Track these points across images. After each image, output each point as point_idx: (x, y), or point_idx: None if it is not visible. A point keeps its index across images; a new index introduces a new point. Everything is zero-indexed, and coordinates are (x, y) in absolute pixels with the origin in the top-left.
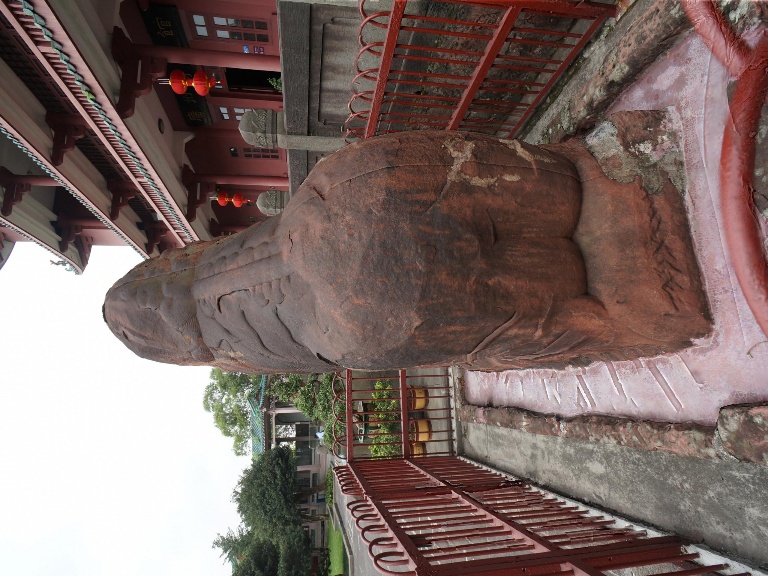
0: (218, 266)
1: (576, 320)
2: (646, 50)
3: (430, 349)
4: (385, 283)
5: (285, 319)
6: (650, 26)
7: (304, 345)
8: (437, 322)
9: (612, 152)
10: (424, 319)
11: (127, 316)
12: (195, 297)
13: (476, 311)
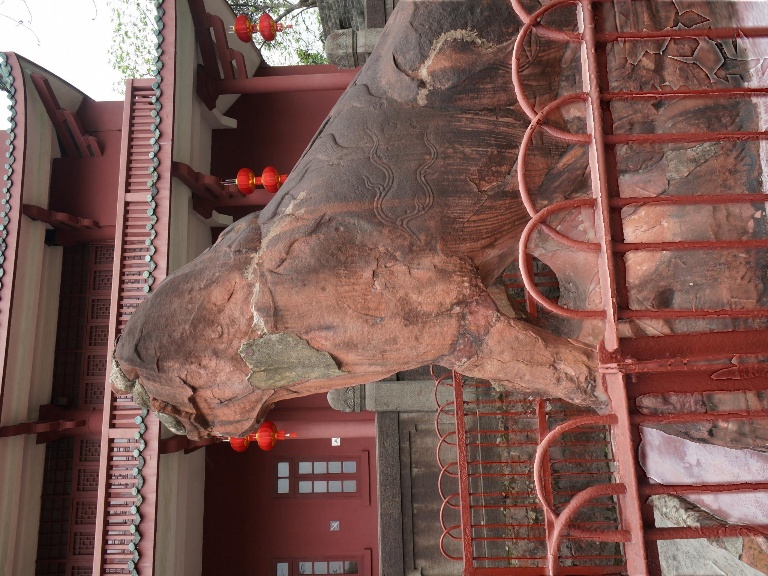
0: None
1: None
2: None
3: None
4: None
5: (363, 79)
6: None
7: (381, 94)
8: None
9: None
10: None
11: None
12: None
13: None
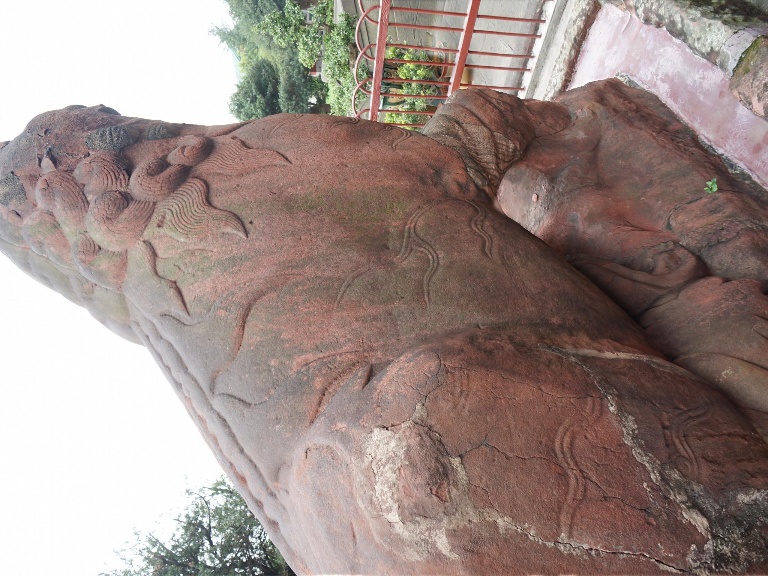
0: (172, 369)
1: None
2: None
3: None
4: None
5: None
6: None
7: None
8: None
9: None
10: None
11: None
12: None
13: None
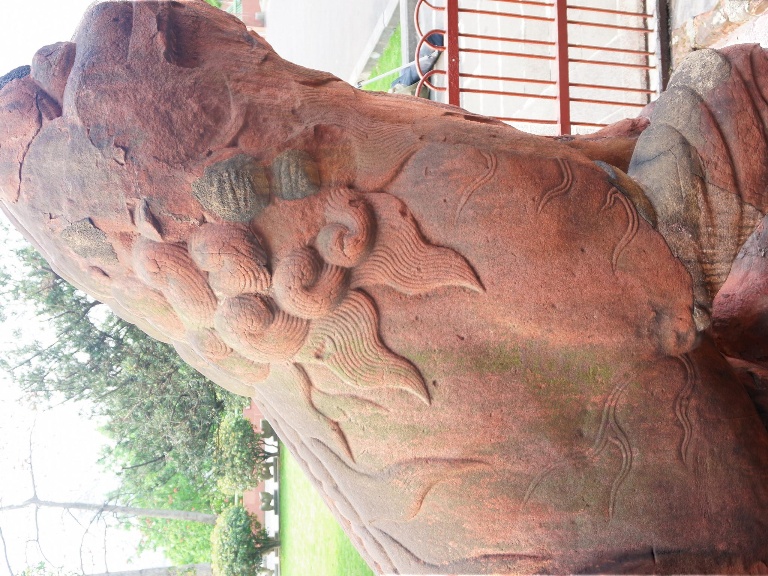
0: None
1: None
2: None
3: None
4: None
5: None
6: None
7: None
8: None
9: None
10: None
11: None
12: None
13: None
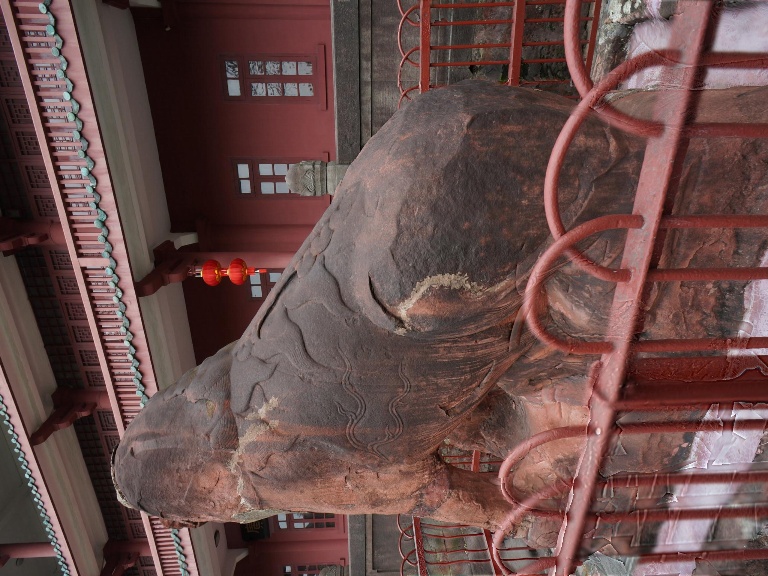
0: None
1: (648, 135)
2: (605, 84)
3: (492, 160)
4: (429, 114)
5: (333, 264)
6: (598, 73)
7: (355, 306)
8: (488, 119)
9: (610, 97)
10: (473, 114)
11: (145, 418)
12: (233, 353)
13: (525, 106)
